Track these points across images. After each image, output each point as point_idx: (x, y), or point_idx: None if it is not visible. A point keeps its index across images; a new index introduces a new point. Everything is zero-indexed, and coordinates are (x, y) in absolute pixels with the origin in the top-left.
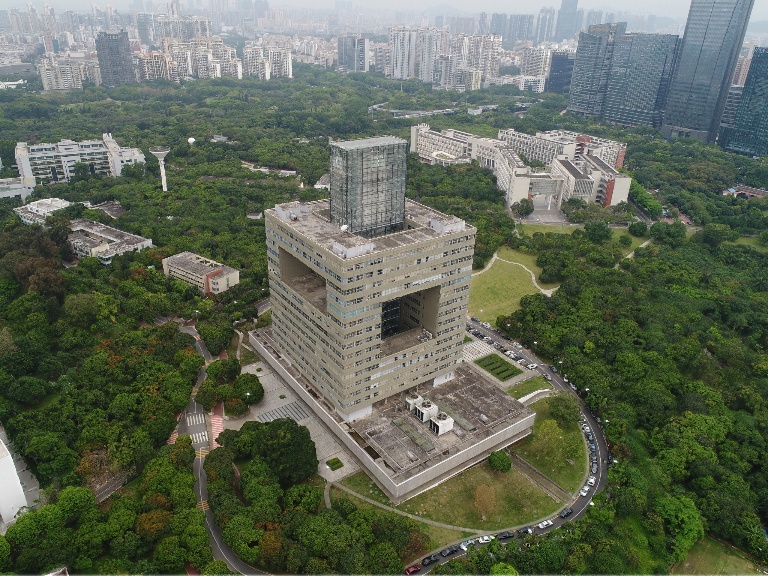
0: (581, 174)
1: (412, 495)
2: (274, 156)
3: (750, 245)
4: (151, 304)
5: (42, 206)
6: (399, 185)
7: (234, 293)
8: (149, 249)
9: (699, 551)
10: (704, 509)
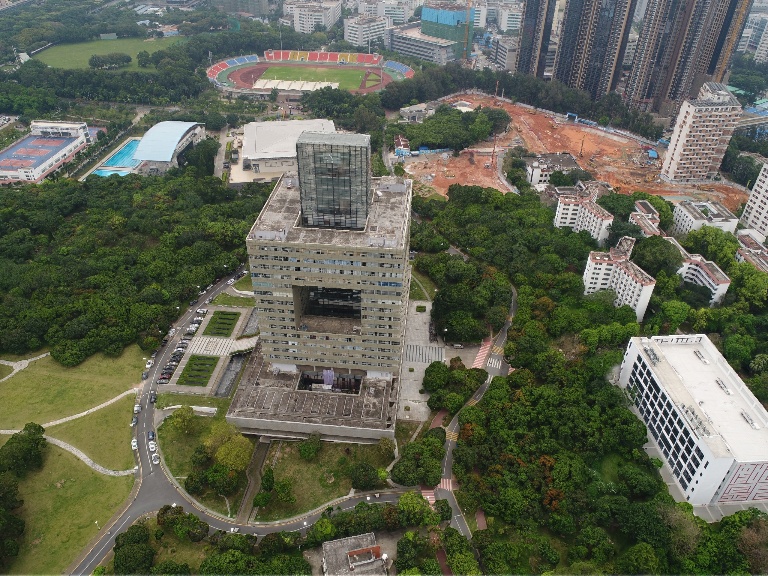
0: None
1: None
2: None
3: None
4: None
5: None
6: None
7: None
8: None
9: None
10: None
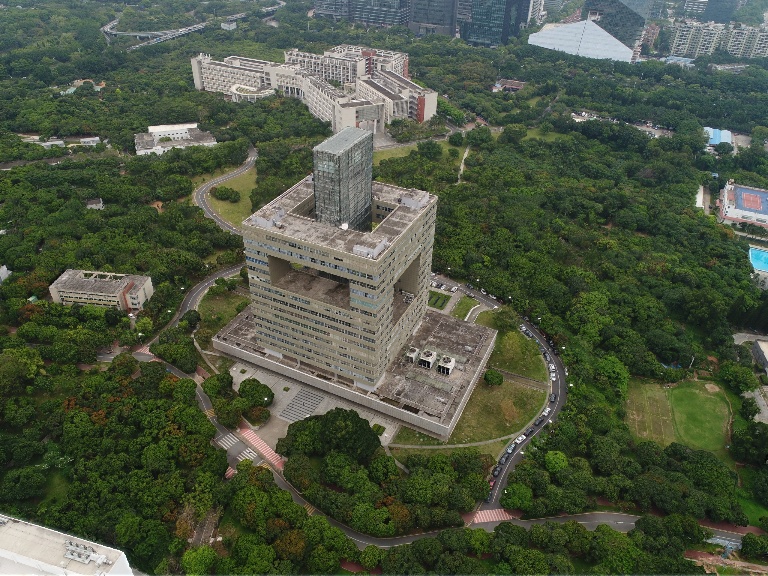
0: (392, 94)
1: (452, 429)
2: (55, 121)
3: (541, 138)
4: (79, 342)
5: None
6: (368, 172)
7: (160, 302)
8: (15, 278)
9: (629, 389)
10: (625, 360)
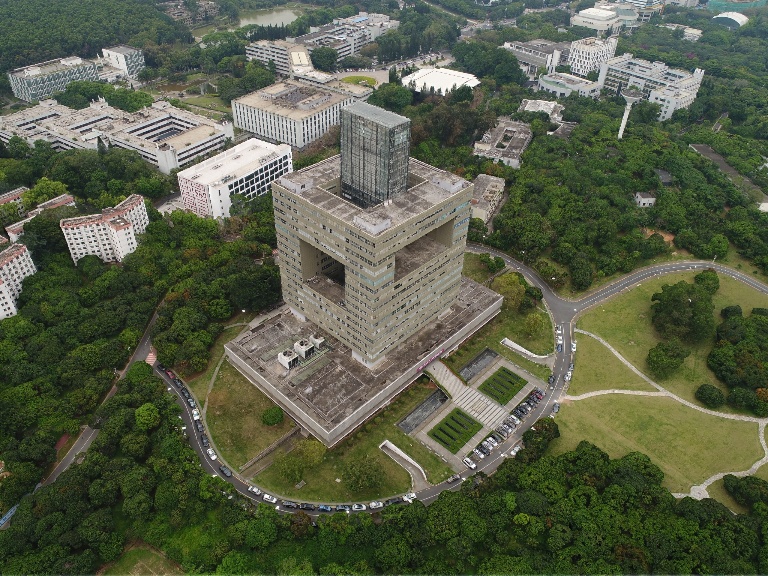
0: None
1: (236, 367)
2: None
3: None
4: None
5: (532, 104)
6: (383, 165)
7: None
8: (500, 164)
9: None
10: None
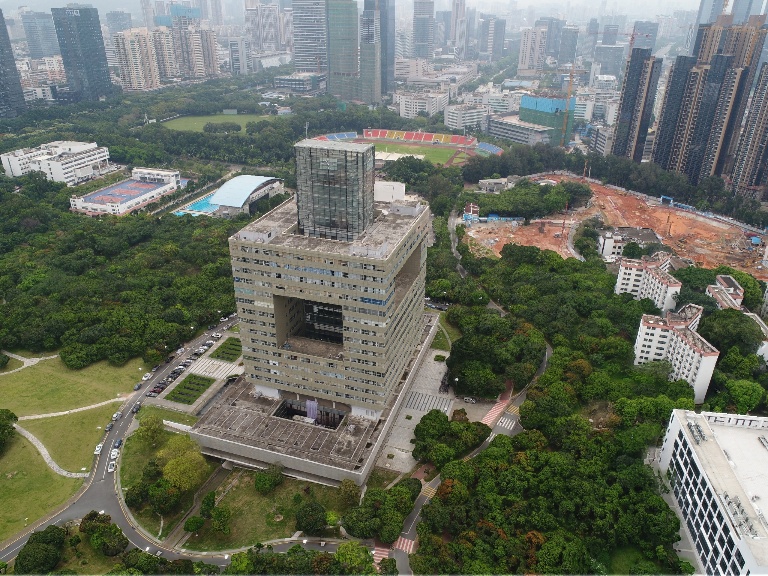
0: None
1: None
2: None
3: None
4: None
5: None
6: None
7: (281, 563)
8: None
9: None
10: None
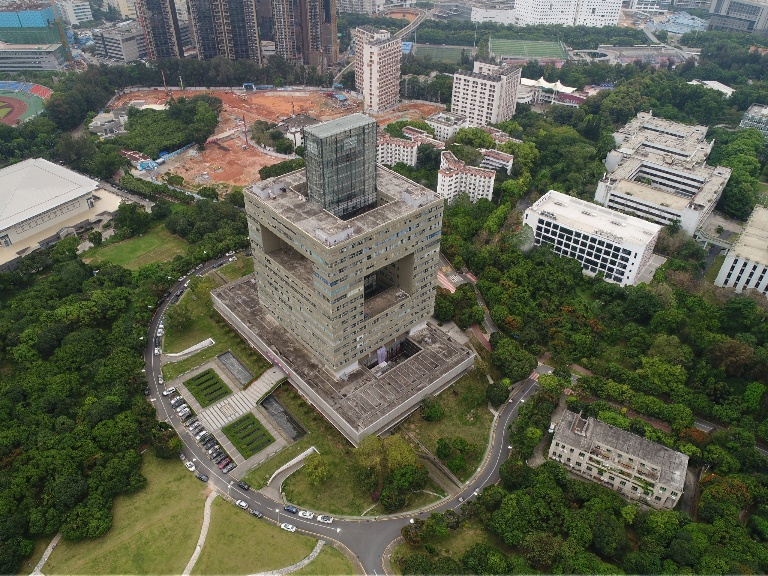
0: None
1: None
2: None
3: None
4: None
5: None
6: None
7: None
8: None
9: None
10: None
